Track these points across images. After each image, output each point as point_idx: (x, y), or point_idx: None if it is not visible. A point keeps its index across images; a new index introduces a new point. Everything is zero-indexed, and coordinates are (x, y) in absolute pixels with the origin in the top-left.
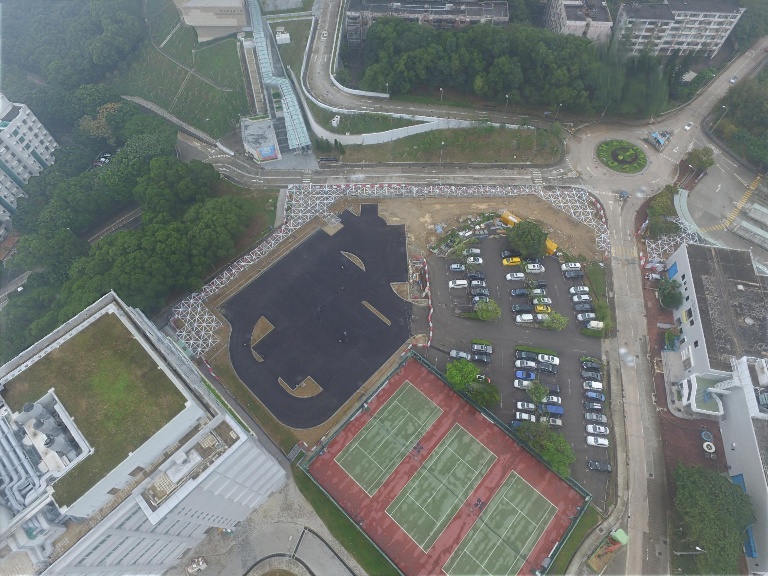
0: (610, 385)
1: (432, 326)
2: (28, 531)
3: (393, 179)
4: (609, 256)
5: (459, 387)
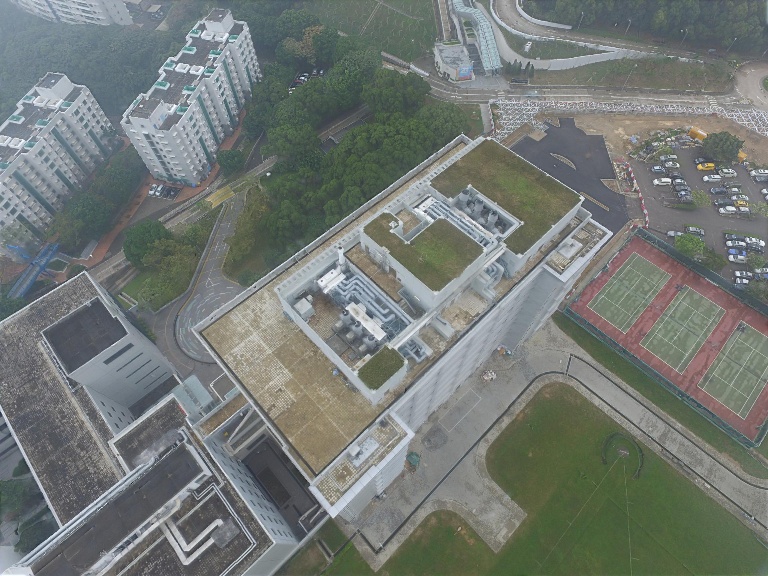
0: None
1: (647, 213)
2: None
3: (582, 99)
4: None
5: (690, 254)
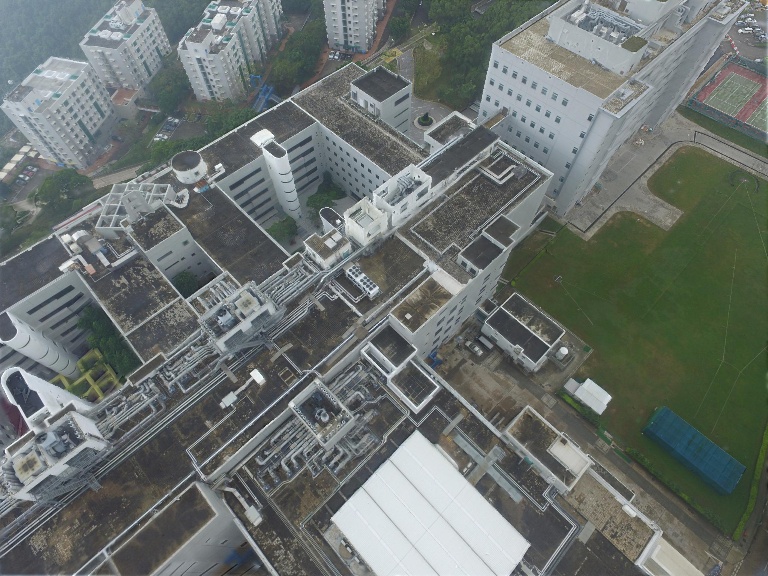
0: None
1: None
2: None
3: None
4: None
5: None
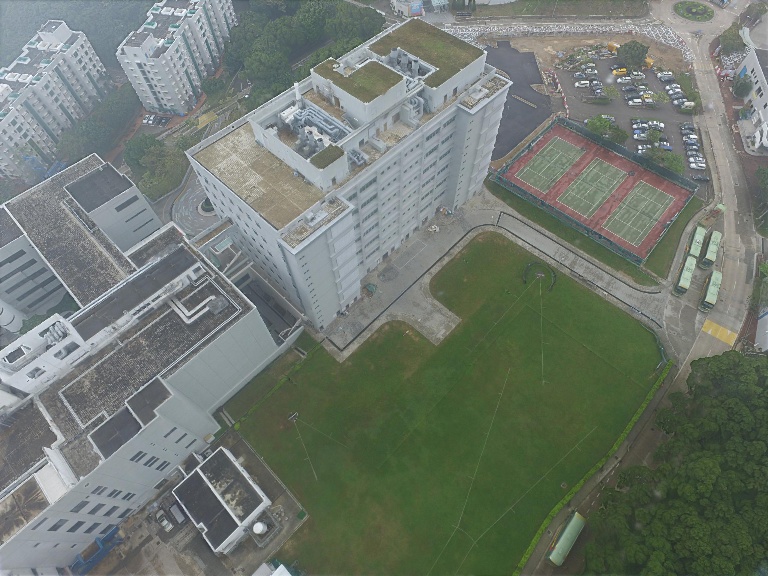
0: (702, 140)
1: (568, 107)
2: None
3: None
4: (692, 69)
5: (599, 131)
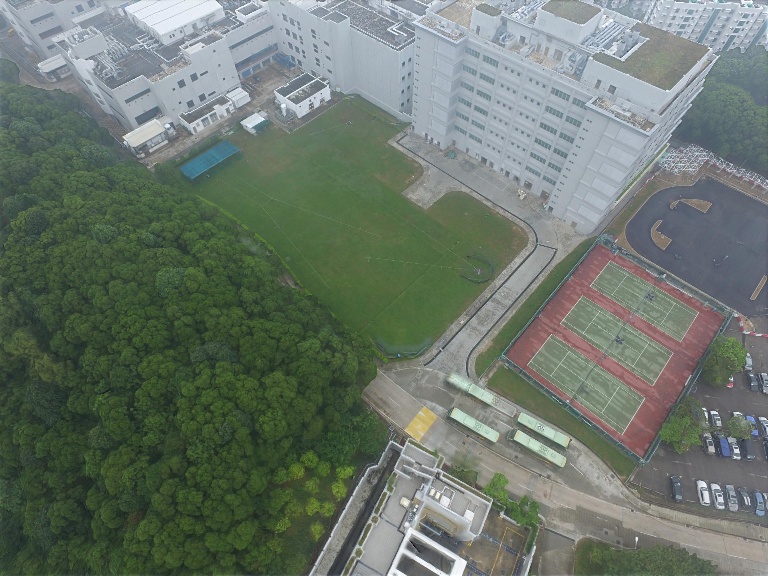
0: None
1: None
2: (572, 55)
3: None
4: None
5: (714, 347)
